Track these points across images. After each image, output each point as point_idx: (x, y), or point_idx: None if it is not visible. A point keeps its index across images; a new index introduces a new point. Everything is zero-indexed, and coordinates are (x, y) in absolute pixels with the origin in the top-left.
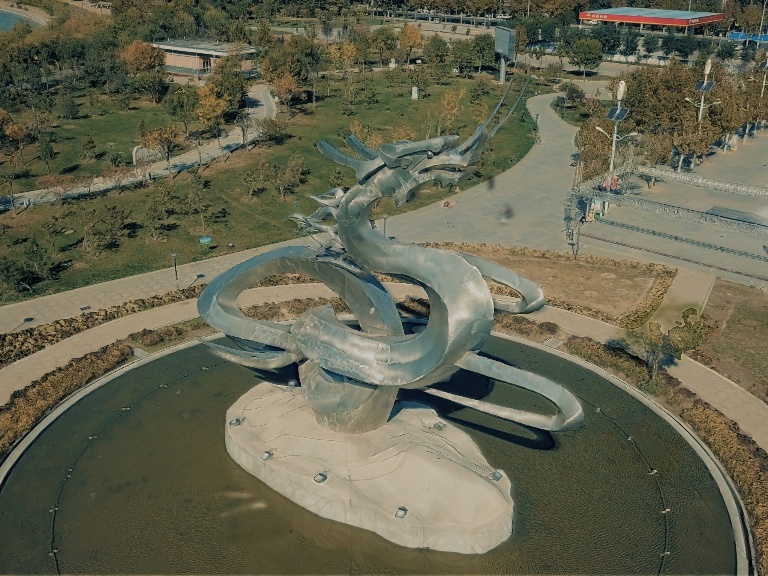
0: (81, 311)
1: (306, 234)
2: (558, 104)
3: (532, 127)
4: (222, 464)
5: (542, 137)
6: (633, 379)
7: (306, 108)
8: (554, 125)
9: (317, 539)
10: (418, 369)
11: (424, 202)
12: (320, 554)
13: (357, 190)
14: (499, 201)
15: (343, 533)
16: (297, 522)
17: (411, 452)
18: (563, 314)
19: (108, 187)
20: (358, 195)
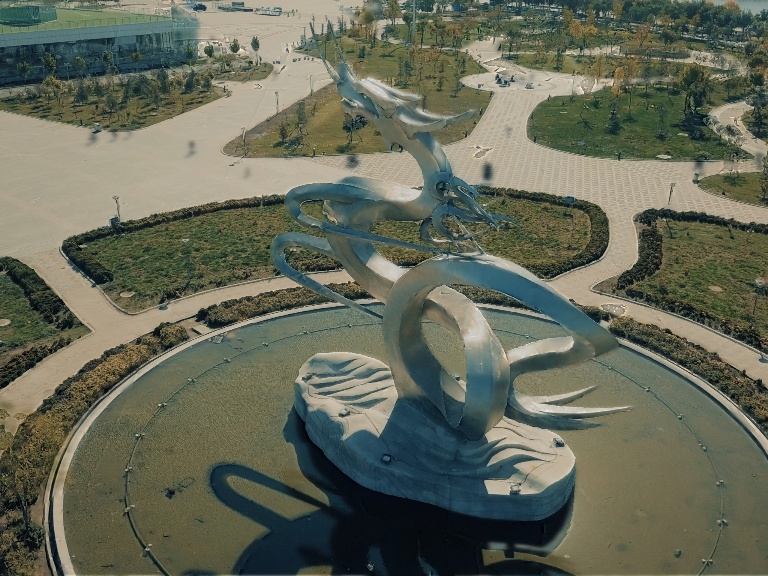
0: None
1: None
2: None
3: None
4: None
5: None
6: None
7: None
8: None
9: None
10: None
11: None
12: None
13: None
14: None
15: None
16: None
17: None
18: None
19: None
20: None
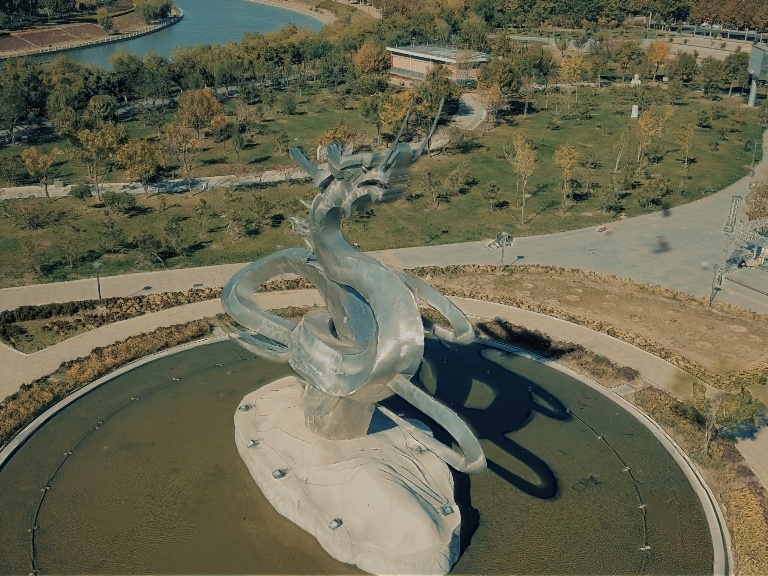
0: (193, 287)
1: (436, 243)
2: None
3: None
4: (230, 445)
5: (760, 169)
6: (690, 444)
7: (514, 119)
8: None
9: (277, 533)
10: (354, 383)
11: (578, 225)
12: (283, 549)
13: (319, 198)
14: (663, 233)
15: (293, 532)
16: (265, 513)
17: (364, 467)
18: (654, 362)
19: (282, 179)
20: (320, 203)
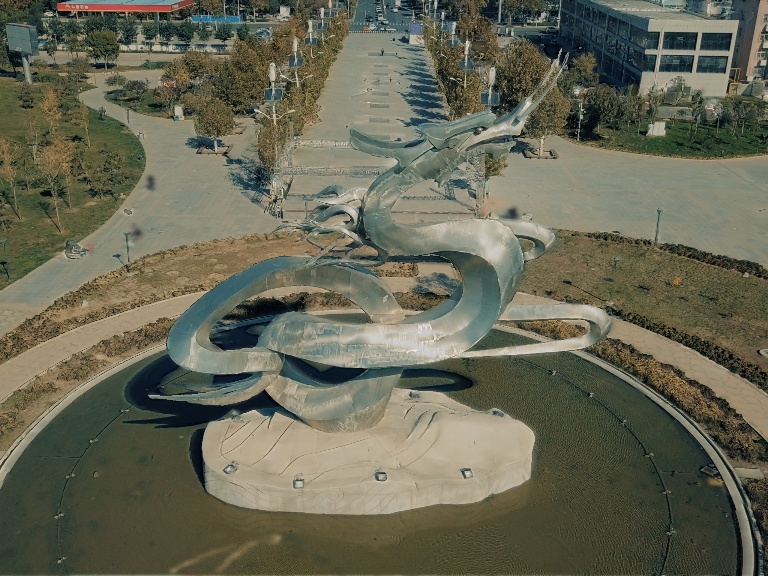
0: None
1: (18, 275)
2: (116, 98)
3: (117, 124)
4: (224, 520)
5: None
6: None
7: None
8: (134, 119)
9: None
10: (473, 334)
11: (104, 215)
12: None
13: (393, 180)
14: (174, 198)
15: (409, 520)
16: (352, 534)
17: (443, 419)
18: None
19: None
20: (394, 184)
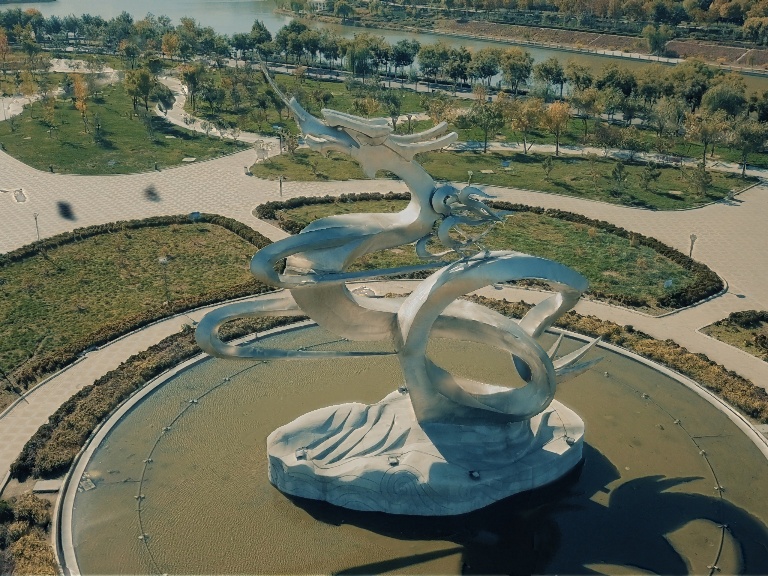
0: None
1: None
2: None
3: None
4: None
5: None
6: None
7: None
8: None
9: None
10: None
11: None
12: None
13: None
14: None
15: None
16: None
17: None
18: None
19: None
20: None
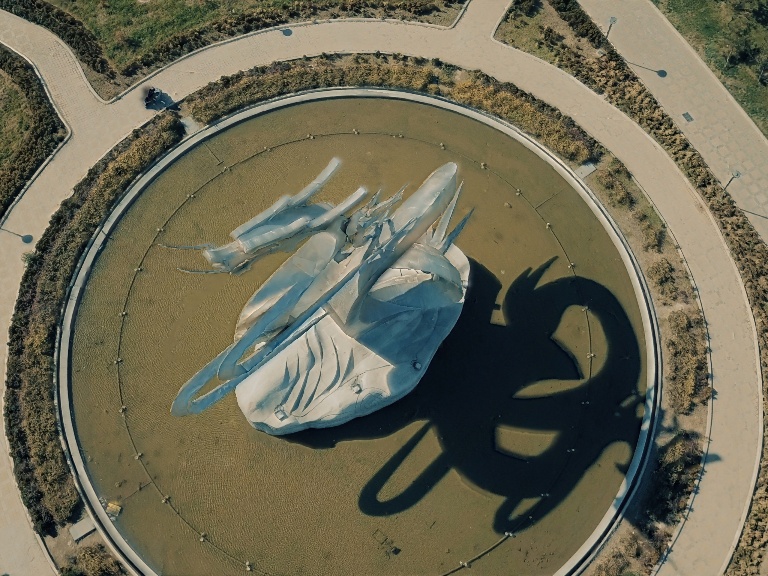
0: (681, 114)
1: None
2: None
3: None
4: None
5: None
6: None
7: None
8: None
9: None
10: None
11: None
12: None
13: None
14: None
15: None
16: None
17: (298, 343)
18: None
19: None
20: None
